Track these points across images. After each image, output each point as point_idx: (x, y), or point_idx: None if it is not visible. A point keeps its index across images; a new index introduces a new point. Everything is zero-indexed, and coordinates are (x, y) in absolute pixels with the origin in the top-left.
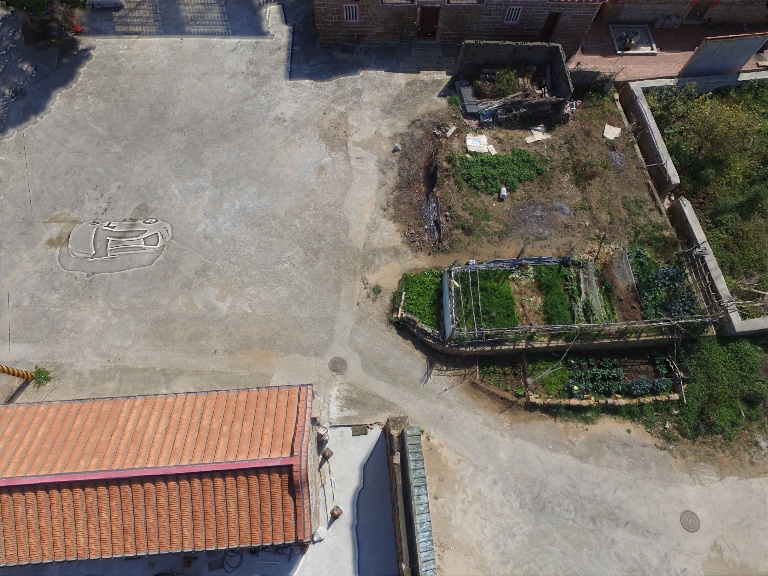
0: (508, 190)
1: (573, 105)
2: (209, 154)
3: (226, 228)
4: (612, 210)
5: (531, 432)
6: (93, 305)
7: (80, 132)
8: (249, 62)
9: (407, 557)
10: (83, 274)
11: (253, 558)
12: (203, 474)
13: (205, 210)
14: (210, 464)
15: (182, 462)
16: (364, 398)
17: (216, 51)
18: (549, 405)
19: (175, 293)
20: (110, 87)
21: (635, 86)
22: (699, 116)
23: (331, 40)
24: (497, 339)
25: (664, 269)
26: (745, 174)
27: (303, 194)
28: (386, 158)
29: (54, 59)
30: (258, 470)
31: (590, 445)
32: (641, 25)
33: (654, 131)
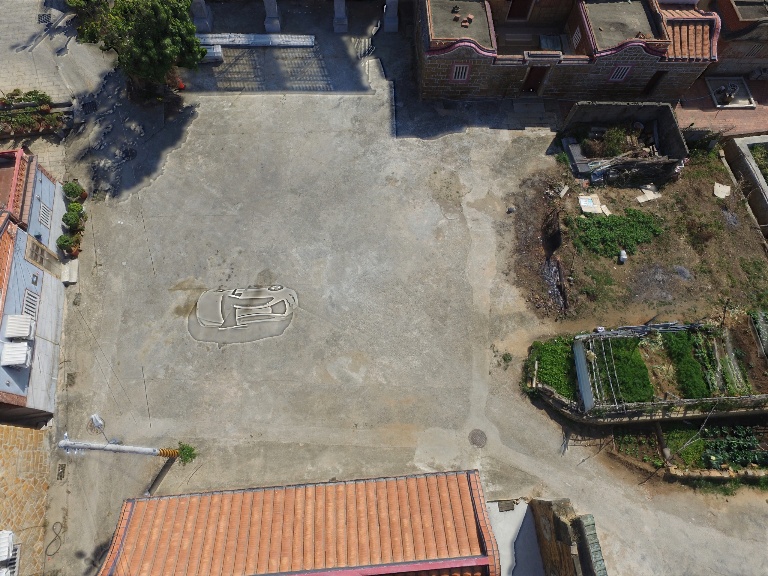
0: (627, 252)
1: (681, 163)
2: (326, 217)
3: (351, 294)
4: (732, 273)
5: (672, 504)
6: (229, 377)
7: (195, 194)
8: (354, 119)
9: None
10: (215, 344)
11: None
12: (397, 574)
13: (328, 276)
14: (405, 565)
15: (374, 561)
16: (507, 472)
17: (320, 108)
18: (688, 476)
19: (309, 364)
20: (219, 147)
21: (741, 143)
22: None
23: (434, 96)
24: (635, 410)
25: None
26: None
27: (424, 258)
28: (502, 220)
29: (161, 118)
30: (451, 569)
31: (732, 517)
32: (736, 77)
33: (765, 190)
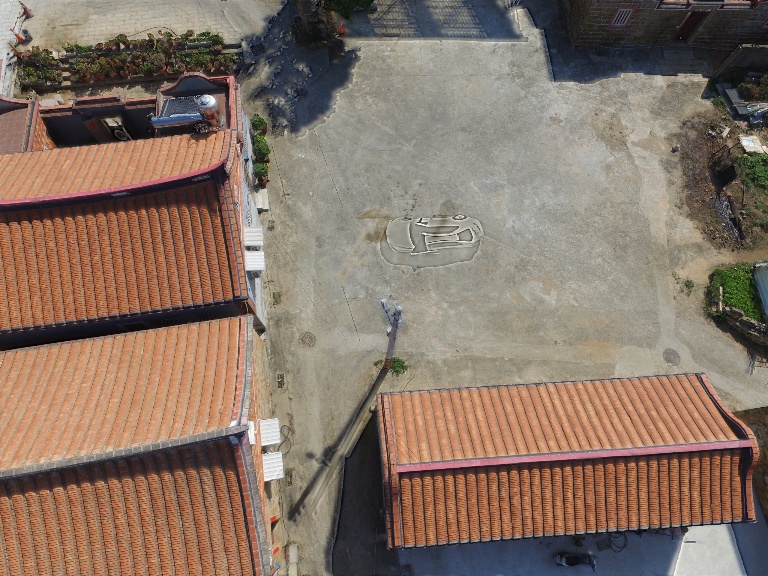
0: None
1: None
2: (498, 153)
3: (533, 224)
4: None
5: None
6: (427, 298)
7: (369, 131)
8: (511, 64)
9: None
10: (409, 268)
11: (636, 539)
12: (662, 456)
13: (509, 207)
14: (671, 446)
15: (637, 444)
16: None
17: (477, 53)
18: None
19: (502, 287)
20: (385, 88)
21: None
22: None
23: (587, 43)
24: None
25: None
26: None
27: (597, 192)
28: (668, 158)
29: (326, 60)
30: (712, 452)
31: None
32: None
33: None
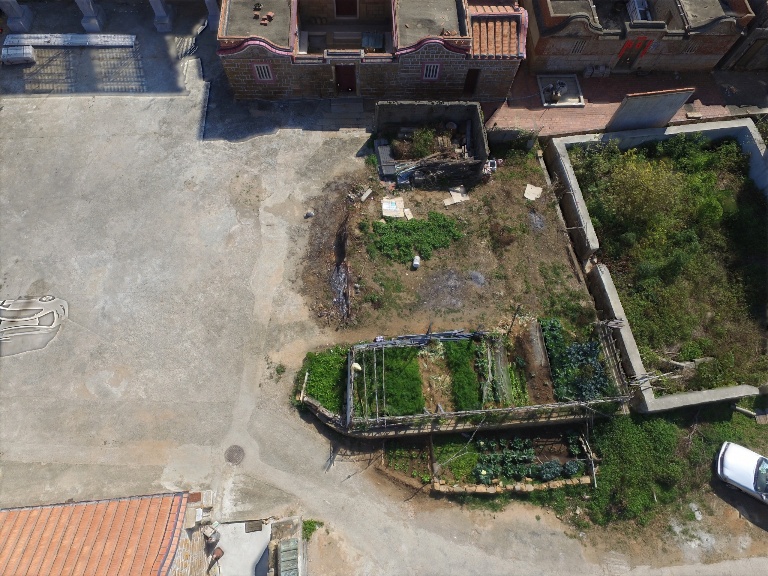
0: (422, 258)
1: (494, 164)
2: (114, 223)
3: (126, 305)
4: (529, 278)
5: (436, 522)
6: None
7: None
8: (162, 121)
9: None
10: None
11: None
12: None
13: (105, 285)
14: None
15: None
16: (260, 490)
17: (129, 110)
18: (455, 492)
19: (67, 378)
20: (15, 151)
21: (558, 143)
22: (619, 177)
23: (248, 97)
24: (400, 424)
25: None
26: (669, 234)
27: (209, 266)
28: (298, 225)
29: None
30: None
31: (497, 534)
32: (570, 75)
33: (575, 192)
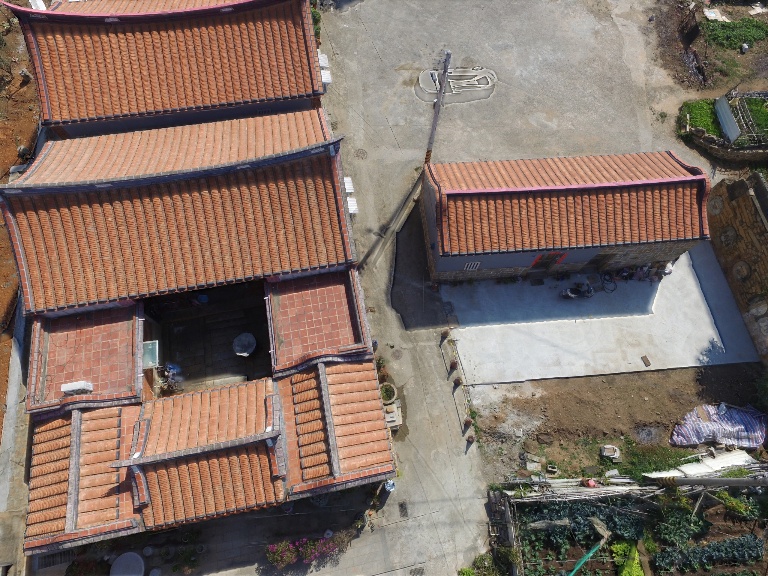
0: None
1: None
2: (506, 23)
3: (537, 73)
4: None
5: None
6: (454, 124)
7: (400, 8)
8: None
9: None
10: None
11: (623, 285)
12: (640, 188)
13: (517, 61)
14: (646, 180)
15: None
16: None
17: None
18: None
19: (513, 116)
20: None
21: None
22: None
23: None
24: None
25: None
26: None
27: (588, 50)
28: (645, 25)
29: None
30: (676, 185)
31: None
32: None
33: None
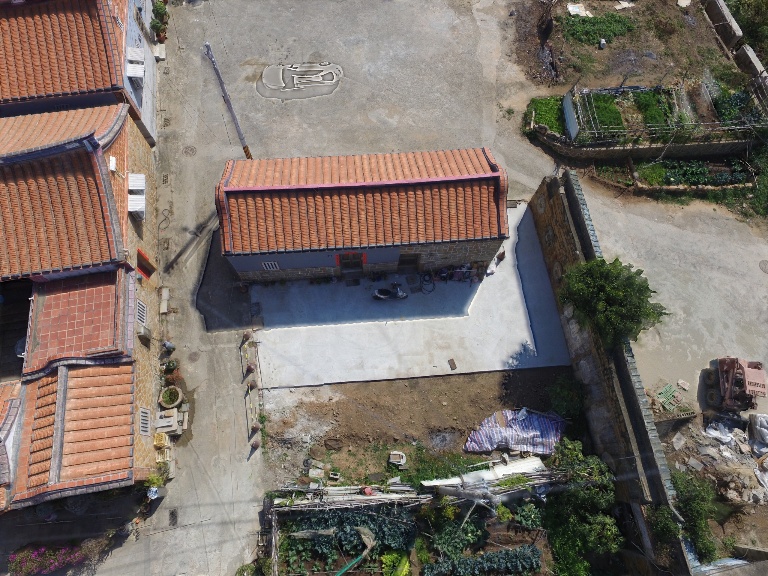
0: (606, 42)
1: None
2: (362, 17)
3: (385, 69)
4: (690, 56)
5: (640, 210)
6: (291, 120)
7: (255, 2)
8: None
9: (580, 246)
10: (279, 100)
11: (443, 285)
12: (433, 185)
13: (367, 56)
14: (439, 177)
15: None
16: (511, 184)
17: None
18: (653, 190)
19: (354, 112)
20: None
21: None
22: None
23: None
24: (611, 140)
25: (735, 95)
26: None
27: (442, 45)
28: (505, 20)
29: None
30: (472, 183)
31: (686, 218)
32: None
33: None
